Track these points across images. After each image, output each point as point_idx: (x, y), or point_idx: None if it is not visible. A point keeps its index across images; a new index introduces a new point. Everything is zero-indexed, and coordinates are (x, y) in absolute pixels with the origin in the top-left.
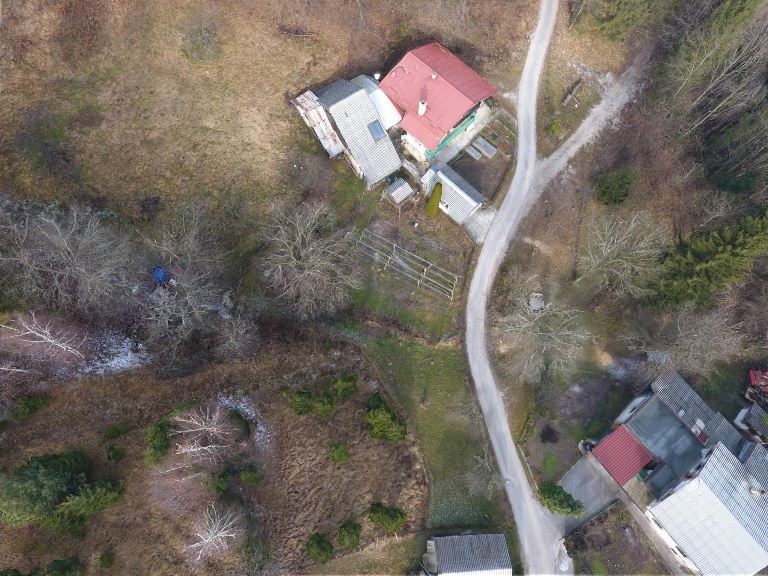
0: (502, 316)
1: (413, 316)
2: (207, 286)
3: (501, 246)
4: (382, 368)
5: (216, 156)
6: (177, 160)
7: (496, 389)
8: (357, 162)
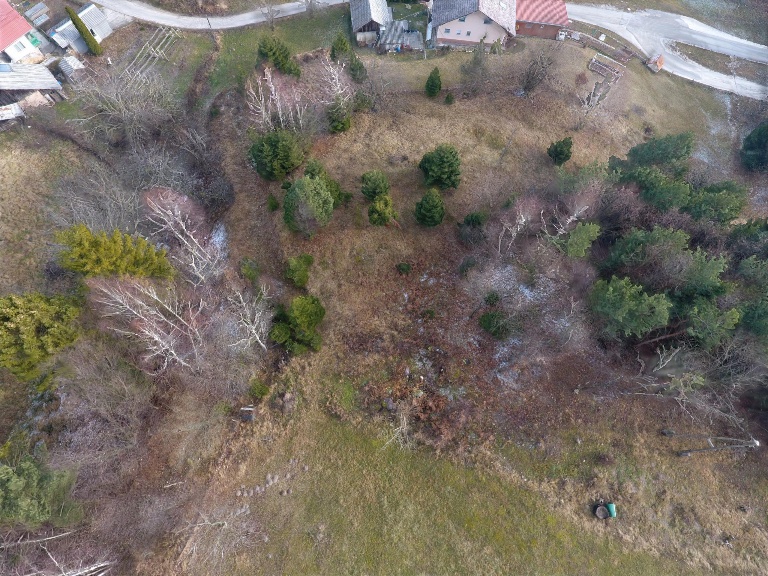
0: (197, 4)
1: (194, 63)
2: (145, 150)
3: (137, 5)
4: (237, 82)
5: (5, 207)
6: (3, 247)
7: (255, 11)
8: (34, 89)
